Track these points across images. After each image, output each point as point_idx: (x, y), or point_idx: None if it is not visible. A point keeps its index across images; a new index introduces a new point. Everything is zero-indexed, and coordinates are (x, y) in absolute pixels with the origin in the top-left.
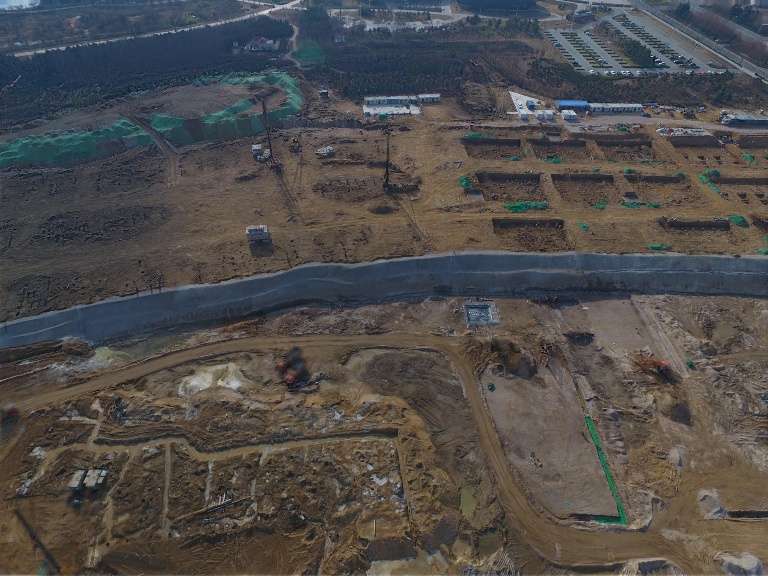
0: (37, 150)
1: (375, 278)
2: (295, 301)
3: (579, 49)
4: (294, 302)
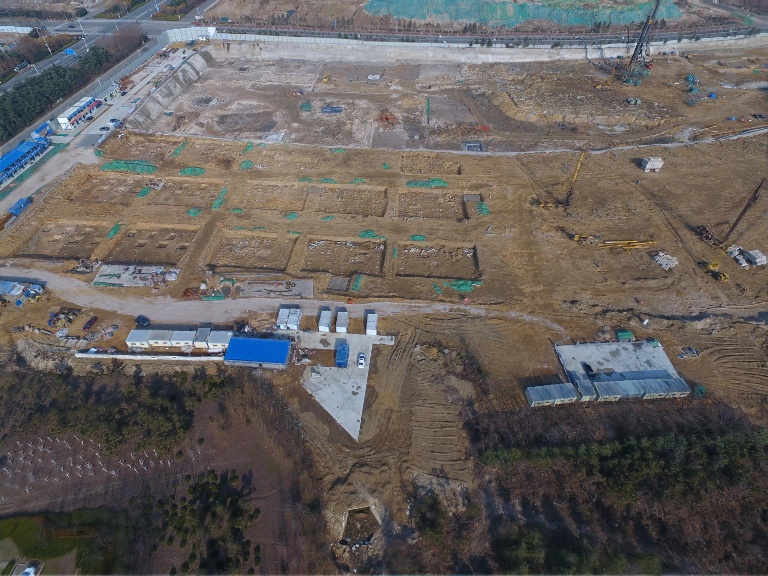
0: None
1: None
2: None
3: None
4: None
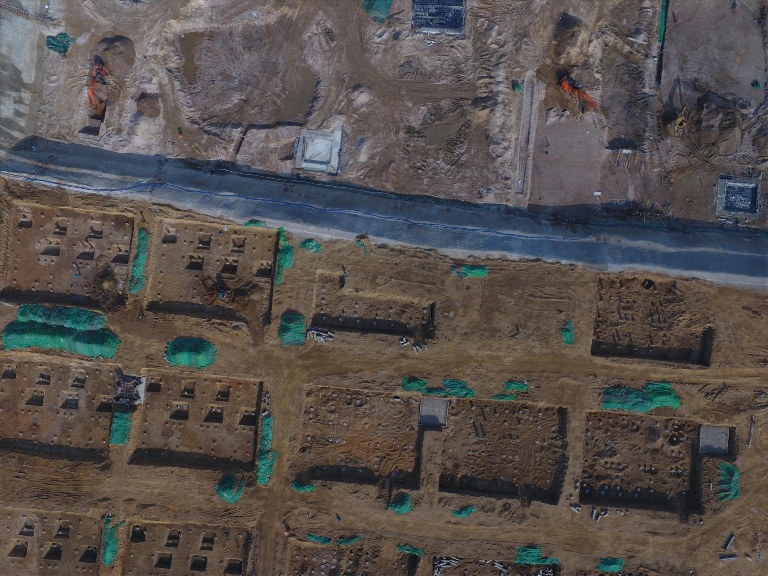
0: None
1: None
2: None
3: None
4: None
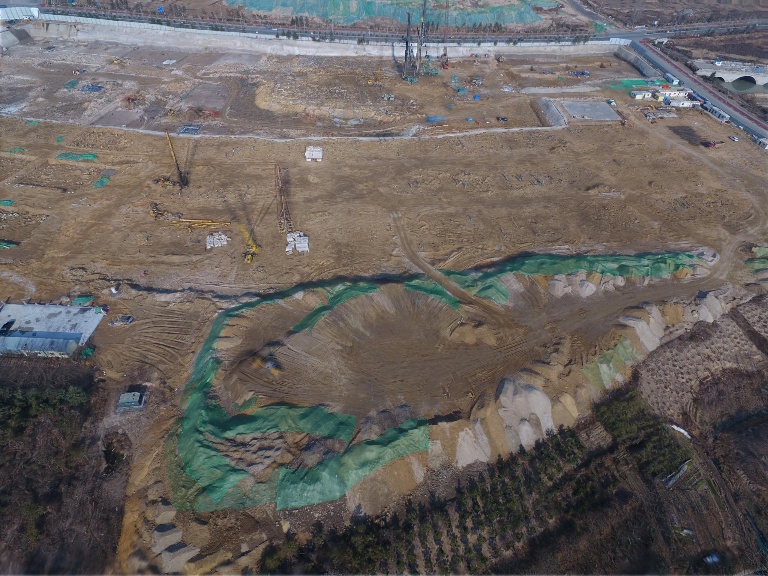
0: None
1: None
2: None
3: None
4: None
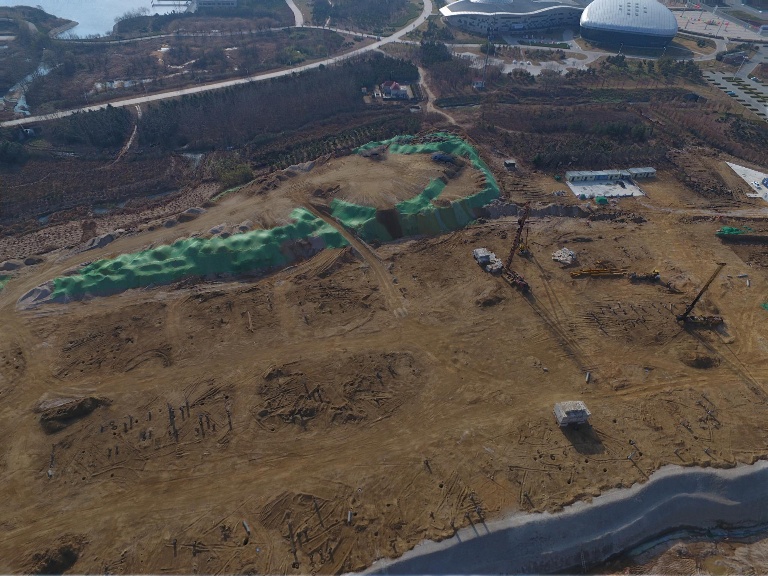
0: (210, 258)
1: (763, 492)
2: (661, 531)
3: (760, 101)
4: (660, 533)
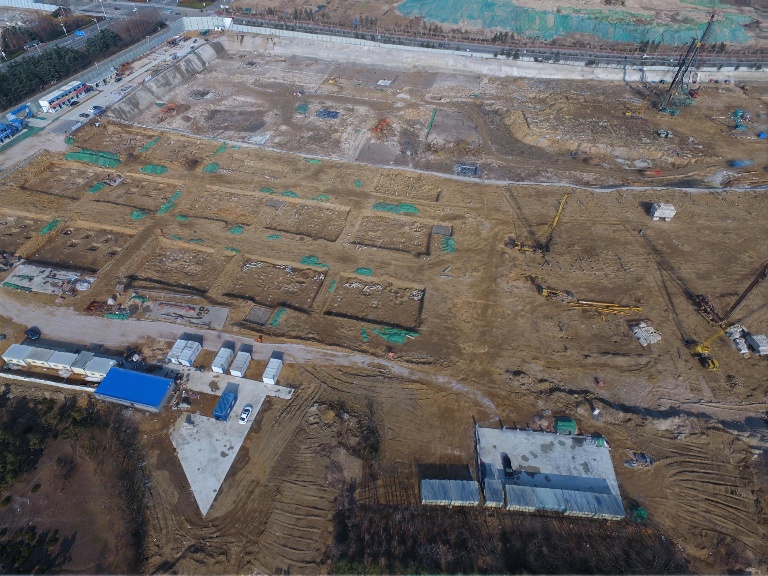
0: None
1: None
2: None
3: None
4: None
